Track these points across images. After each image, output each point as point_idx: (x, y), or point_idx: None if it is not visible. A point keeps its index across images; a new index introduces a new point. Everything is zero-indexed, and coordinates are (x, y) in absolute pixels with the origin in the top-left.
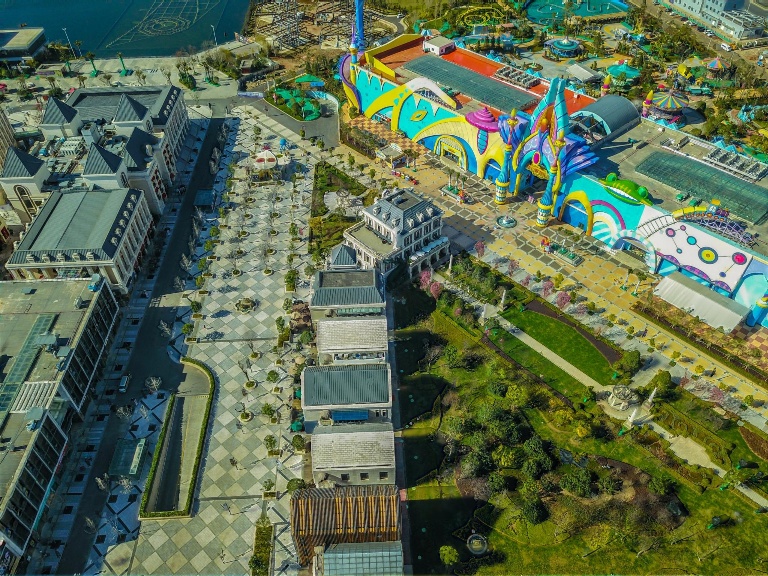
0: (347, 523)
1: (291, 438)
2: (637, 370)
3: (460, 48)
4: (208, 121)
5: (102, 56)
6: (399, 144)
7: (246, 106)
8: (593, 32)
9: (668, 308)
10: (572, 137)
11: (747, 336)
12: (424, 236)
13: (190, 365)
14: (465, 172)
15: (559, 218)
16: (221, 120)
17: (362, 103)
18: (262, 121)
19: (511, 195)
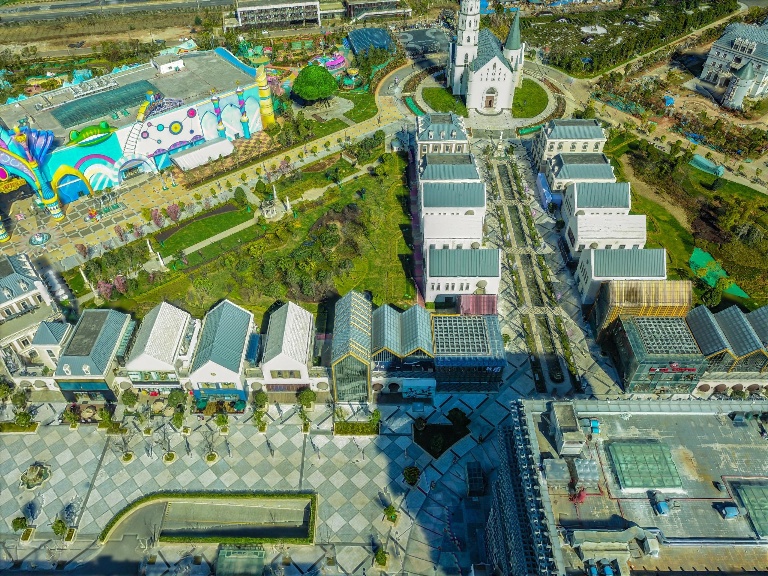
0: (365, 327)
1: (249, 415)
2: None
3: None
4: None
5: None
6: None
7: None
8: None
9: (196, 174)
10: None
11: None
12: None
13: (112, 533)
14: None
15: (60, 205)
16: None
17: None
18: None
19: None
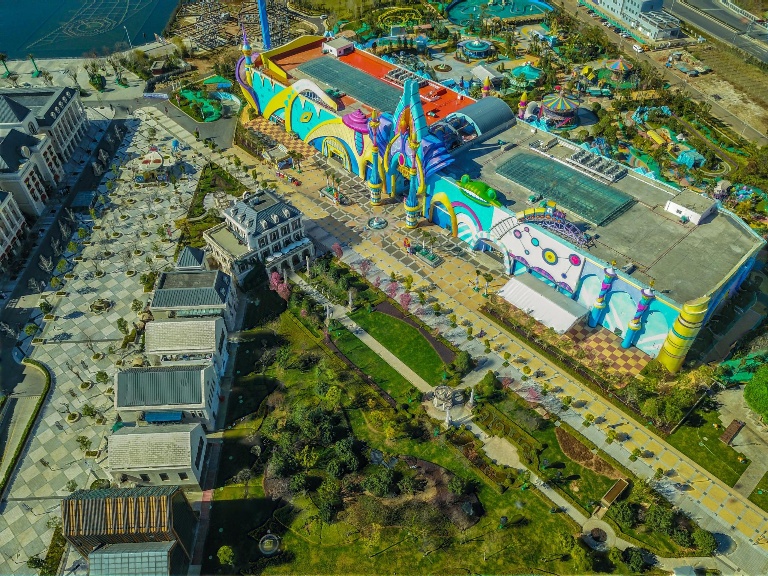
0: (117, 523)
1: None
2: (469, 371)
3: (358, 49)
4: (108, 122)
5: (19, 57)
6: (290, 145)
7: (150, 107)
8: (507, 33)
9: (515, 309)
10: (429, 139)
11: (586, 337)
12: (282, 237)
13: (31, 366)
14: (349, 173)
15: (429, 219)
16: (122, 121)
17: (260, 104)
18: (162, 122)
19: (388, 196)
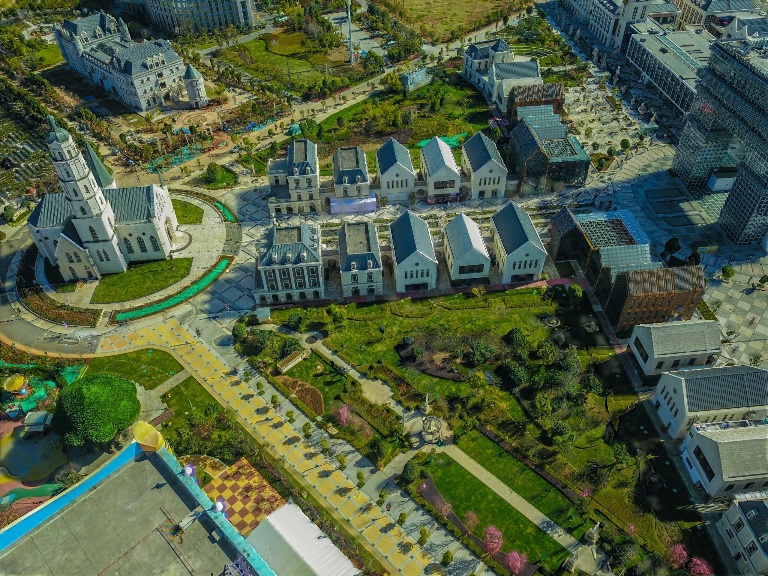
0: None
1: None
2: None
3: None
4: None
5: None
6: None
7: None
8: None
9: None
10: None
11: None
12: None
13: None
14: None
15: None
16: None
17: None
18: None
19: None
